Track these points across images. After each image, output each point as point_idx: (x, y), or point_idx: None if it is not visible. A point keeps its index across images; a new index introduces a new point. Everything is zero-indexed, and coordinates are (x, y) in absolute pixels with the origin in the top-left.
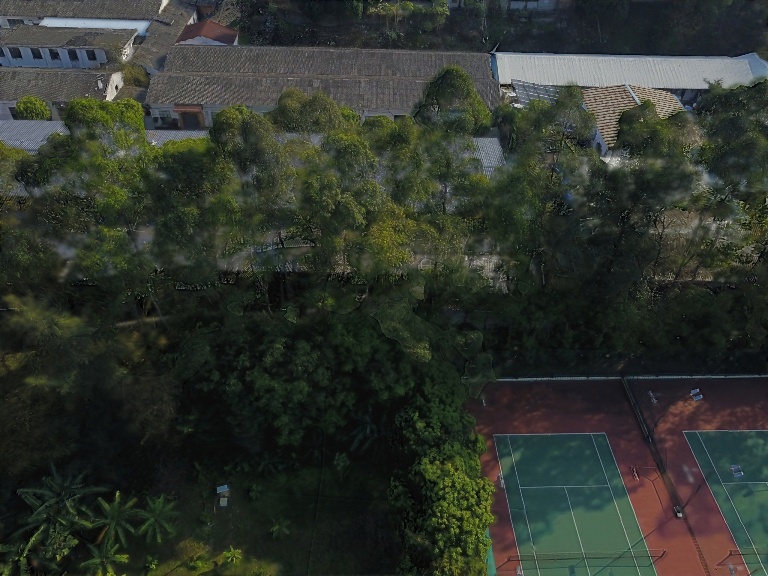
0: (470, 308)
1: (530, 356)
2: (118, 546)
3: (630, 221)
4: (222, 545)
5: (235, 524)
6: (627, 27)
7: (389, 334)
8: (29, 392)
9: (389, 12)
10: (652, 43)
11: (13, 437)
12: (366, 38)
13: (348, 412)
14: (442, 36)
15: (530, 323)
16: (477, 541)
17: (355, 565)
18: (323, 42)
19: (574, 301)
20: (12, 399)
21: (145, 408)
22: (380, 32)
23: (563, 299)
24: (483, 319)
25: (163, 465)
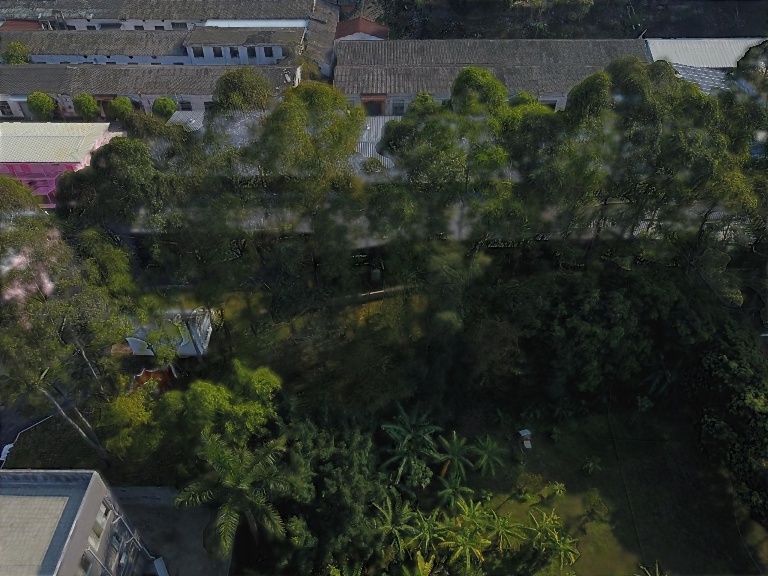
0: None
1: None
2: (460, 479)
3: None
4: (541, 481)
5: (546, 463)
6: (763, 11)
7: (710, 280)
8: (316, 351)
9: (536, 4)
10: None
11: (366, 380)
12: (511, 30)
13: (643, 359)
14: (584, 25)
15: None
16: None
17: (671, 497)
18: (470, 35)
19: None
20: (304, 357)
21: (496, 350)
22: (524, 23)
23: None
24: None
25: (476, 410)
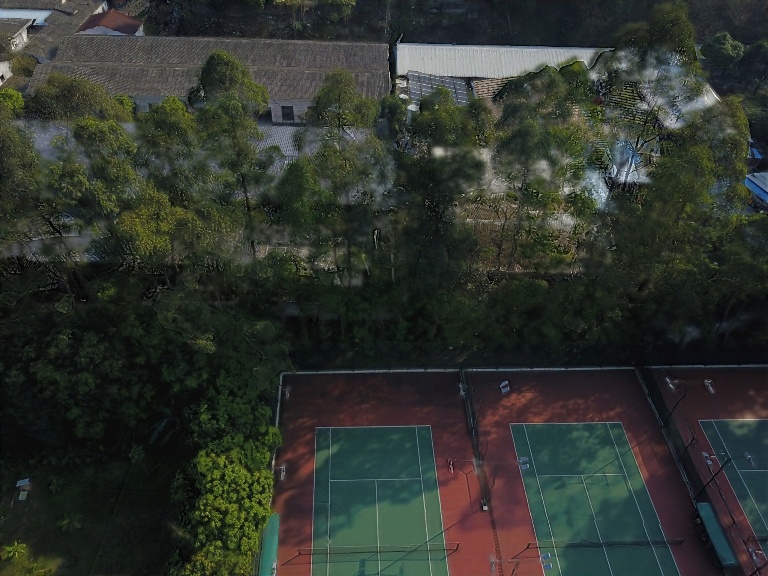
0: (301, 299)
1: (369, 348)
2: None
3: (440, 211)
4: (10, 539)
5: (29, 518)
6: (539, 18)
7: (166, 325)
8: None
9: (294, 2)
10: (562, 34)
11: None
12: (273, 29)
13: (149, 404)
14: (350, 27)
15: (357, 315)
16: (241, 534)
17: (142, 559)
18: (229, 32)
19: (399, 292)
20: None
21: None
22: (287, 23)
23: (389, 290)
24: (316, 311)
25: None
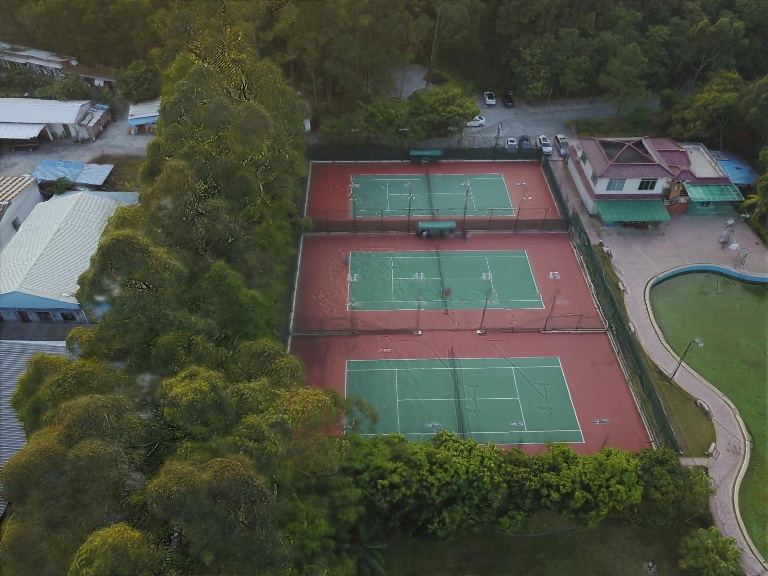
0: None
1: None
2: None
3: None
4: None
5: None
6: None
7: (335, 468)
8: None
9: None
10: None
11: None
12: None
13: None
14: None
15: None
16: None
17: None
18: None
19: None
20: None
21: None
22: None
23: None
24: None
25: None
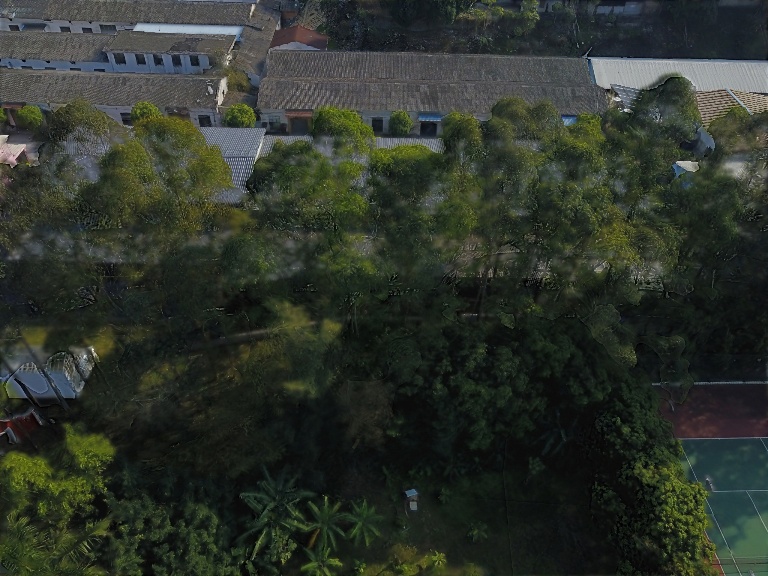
0: (632, 313)
1: None
2: (330, 550)
3: None
4: (422, 549)
5: (430, 528)
6: (713, 32)
7: (601, 340)
8: (200, 396)
9: (480, 17)
10: (739, 47)
11: (228, 441)
12: (455, 43)
13: (537, 417)
14: (530, 41)
15: (696, 328)
16: (702, 545)
17: (558, 569)
18: (413, 47)
19: (742, 306)
20: (185, 403)
21: (366, 413)
22: (468, 37)
23: (731, 304)
24: (643, 324)
25: (357, 469)
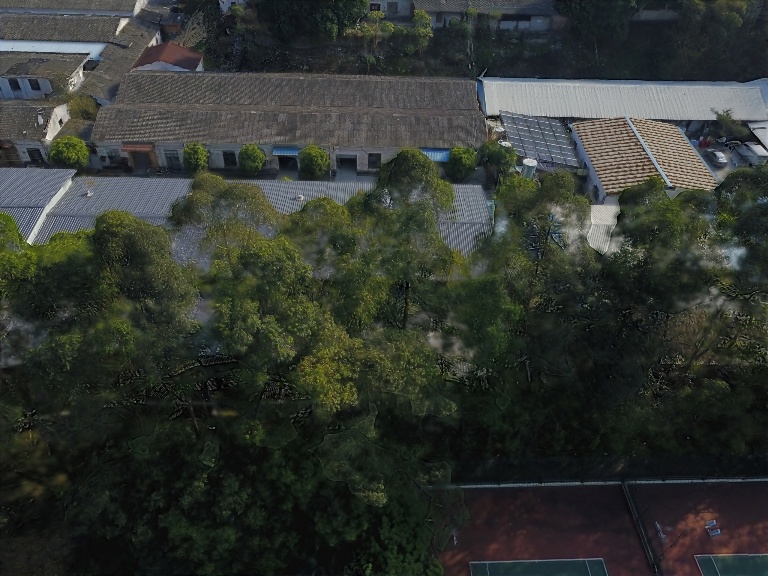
0: None
1: (515, 456)
2: None
3: (632, 316)
4: None
5: None
6: (627, 49)
7: (332, 476)
8: None
9: (367, 34)
10: (654, 67)
11: None
12: (342, 61)
13: (290, 552)
14: (425, 59)
15: (513, 426)
16: None
17: None
18: (295, 66)
19: (565, 402)
20: None
21: None
22: (358, 55)
23: (552, 399)
24: (459, 417)
25: None
